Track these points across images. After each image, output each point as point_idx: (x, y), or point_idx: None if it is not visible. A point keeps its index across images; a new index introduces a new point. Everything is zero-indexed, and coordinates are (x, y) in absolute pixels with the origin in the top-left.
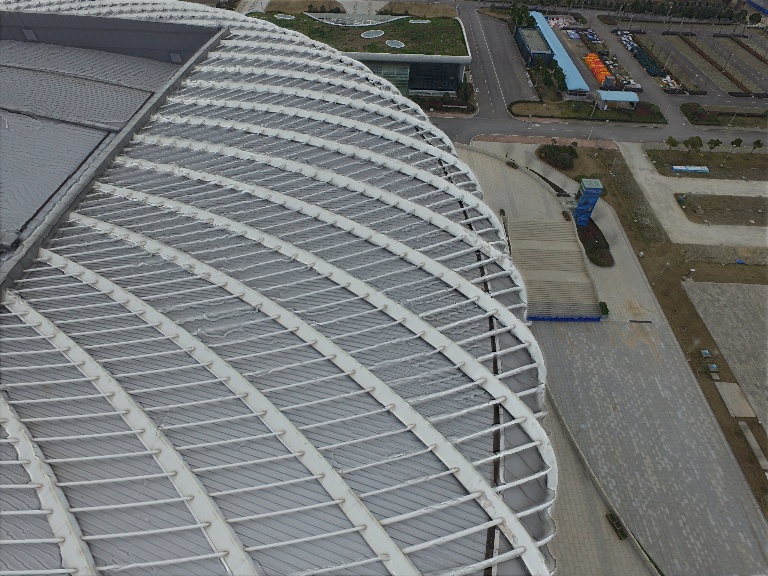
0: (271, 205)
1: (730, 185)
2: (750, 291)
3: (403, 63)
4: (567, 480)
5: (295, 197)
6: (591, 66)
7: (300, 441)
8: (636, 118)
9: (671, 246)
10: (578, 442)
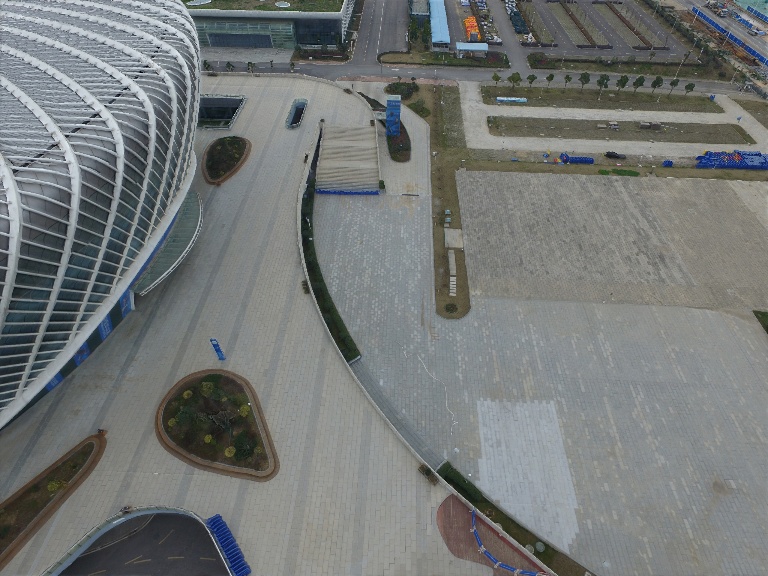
0: None
1: (539, 111)
2: (506, 176)
3: (287, 20)
4: (286, 266)
5: (34, 33)
6: (466, 26)
7: None
8: (484, 64)
9: (464, 150)
10: (323, 261)
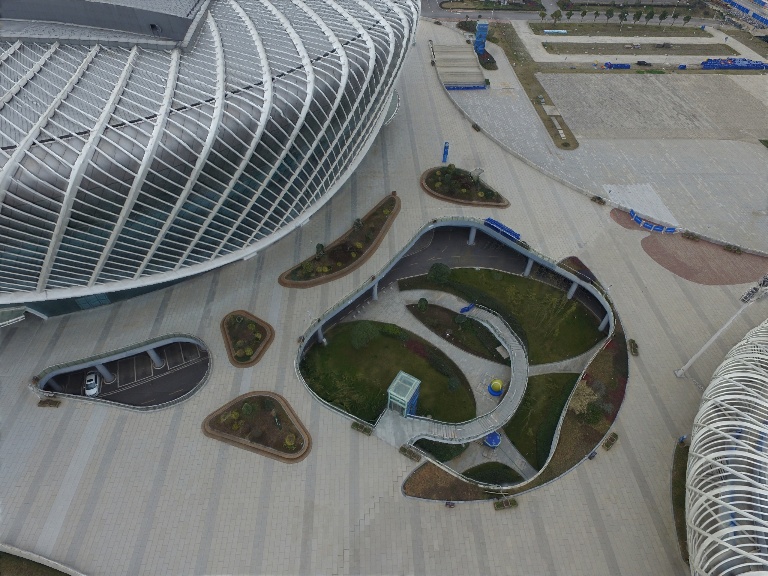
0: None
1: (578, 38)
2: (573, 76)
3: None
4: (456, 119)
5: None
6: None
7: None
8: (525, 8)
9: (534, 63)
10: None
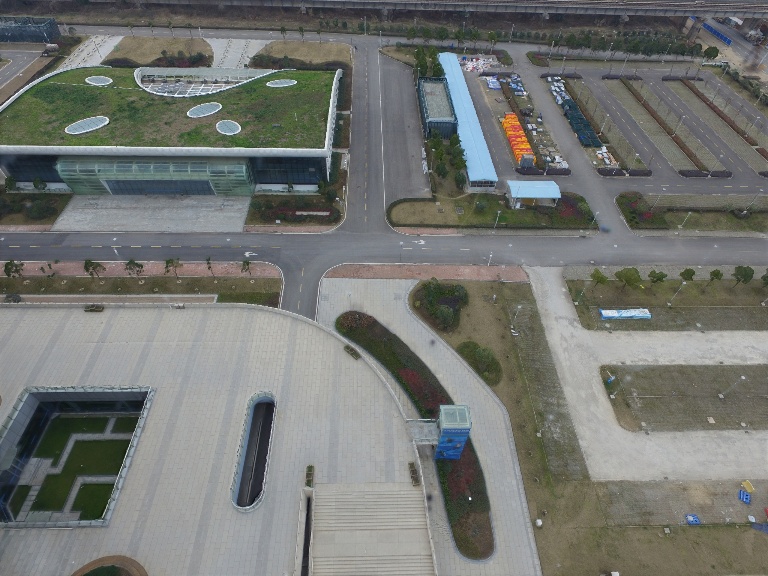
0: None
1: (679, 343)
2: None
3: (235, 158)
4: None
5: None
6: (508, 134)
7: None
8: (557, 223)
9: (588, 490)
10: None
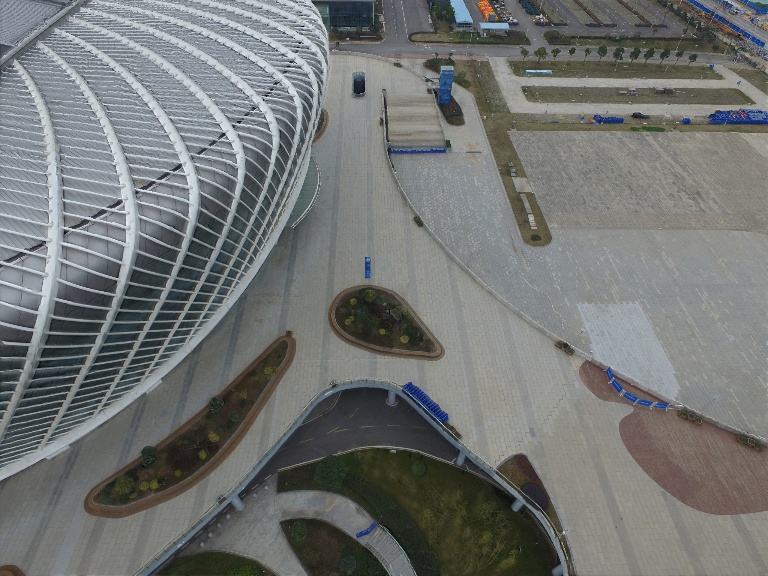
0: (194, 2)
1: (565, 81)
2: (553, 134)
3: (323, 3)
4: (395, 207)
5: None
6: (481, 8)
7: (199, 52)
8: (507, 41)
9: (509, 114)
10: (415, 206)
